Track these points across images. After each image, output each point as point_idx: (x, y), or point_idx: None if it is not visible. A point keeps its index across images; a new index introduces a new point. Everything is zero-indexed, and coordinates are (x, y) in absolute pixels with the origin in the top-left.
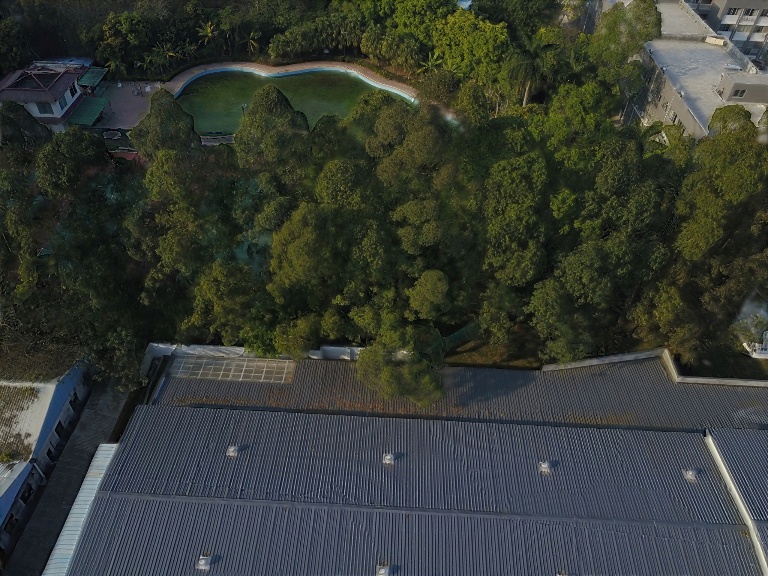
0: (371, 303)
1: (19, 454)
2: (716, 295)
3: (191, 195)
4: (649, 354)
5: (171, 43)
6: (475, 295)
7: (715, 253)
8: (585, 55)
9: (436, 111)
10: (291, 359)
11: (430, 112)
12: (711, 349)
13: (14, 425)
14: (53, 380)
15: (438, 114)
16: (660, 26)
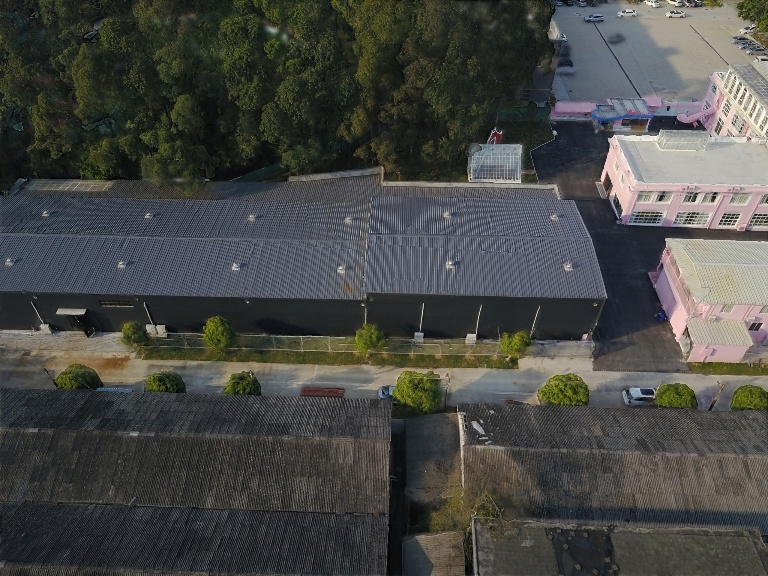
0: (155, 128)
1: None
2: (391, 114)
3: (19, 48)
4: (371, 172)
5: None
6: (233, 124)
7: (397, 88)
8: None
9: None
10: (113, 180)
11: None
12: None
13: None
14: None
15: None
16: None
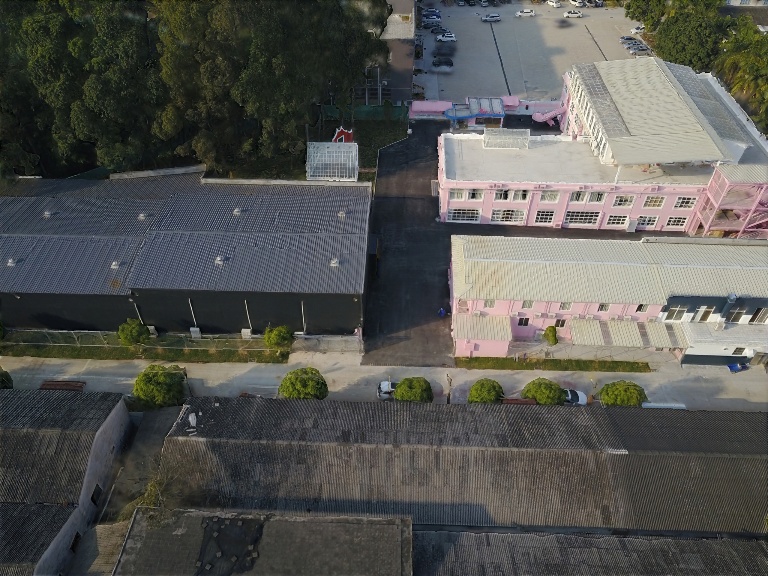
0: None
1: None
2: (200, 112)
3: None
4: (196, 169)
5: None
6: (50, 122)
7: None
8: None
9: None
10: None
11: None
12: None
13: None
14: None
15: None
16: None
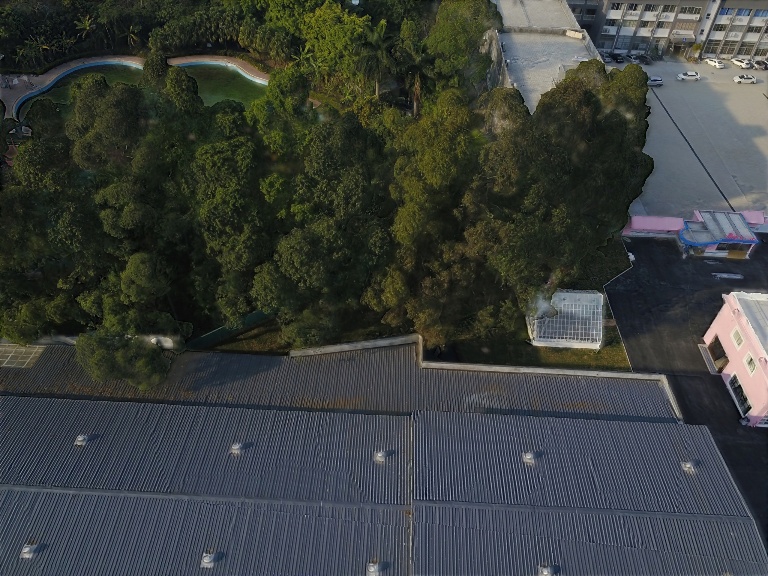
0: (99, 287)
1: None
2: (440, 280)
3: None
4: (405, 340)
5: (46, 36)
6: (213, 280)
7: (448, 238)
8: (424, 47)
9: (135, 94)
10: (42, 345)
11: (124, 95)
12: (495, 337)
13: None
14: None
15: (137, 97)
16: (501, 18)
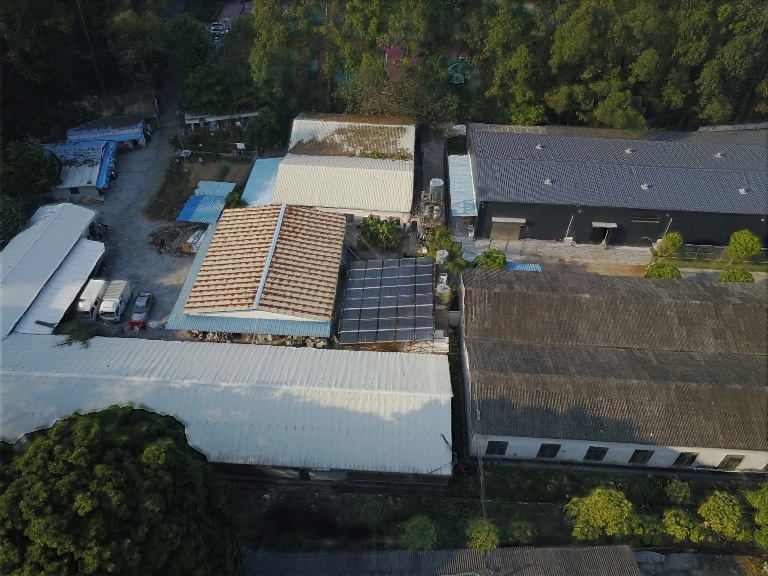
0: (602, 79)
1: (407, 157)
2: None
3: (510, 4)
4: (763, 126)
5: None
6: (661, 79)
7: None
8: None
9: None
10: (541, 125)
11: None
12: None
13: (398, 144)
14: (412, 125)
15: None
16: None
